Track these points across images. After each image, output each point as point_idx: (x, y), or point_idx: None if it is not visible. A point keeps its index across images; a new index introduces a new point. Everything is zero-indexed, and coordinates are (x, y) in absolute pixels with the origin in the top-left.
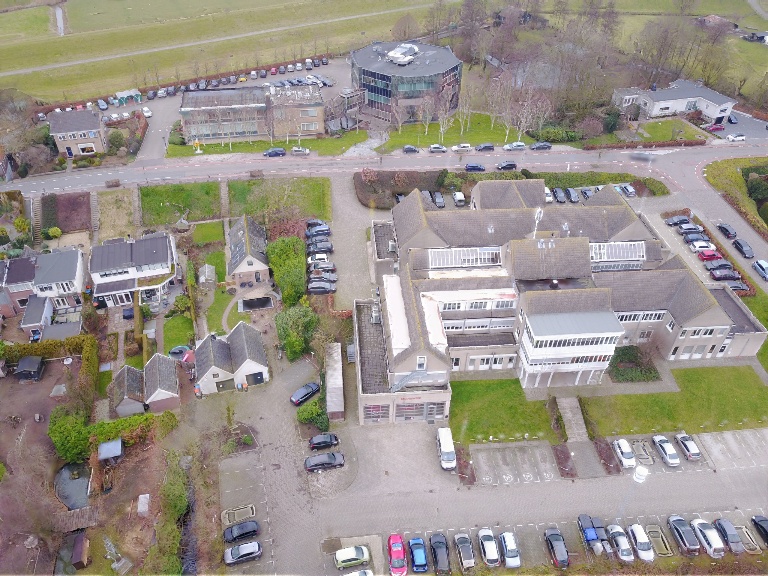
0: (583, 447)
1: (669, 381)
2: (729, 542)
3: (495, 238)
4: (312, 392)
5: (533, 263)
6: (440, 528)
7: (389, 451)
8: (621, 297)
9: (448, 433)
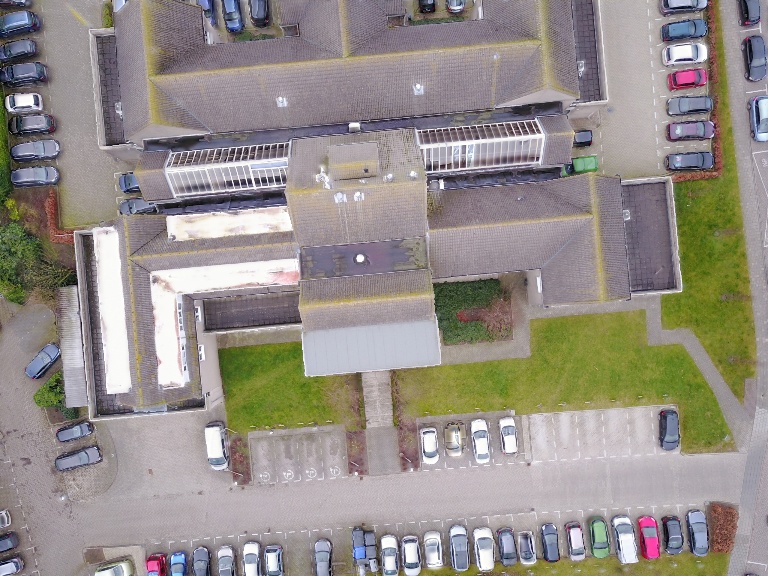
0: (384, 434)
1: (521, 340)
2: (503, 559)
3: (290, 115)
4: (51, 362)
5: (327, 224)
6: (207, 536)
7: (152, 444)
8: (471, 258)
9: (216, 435)
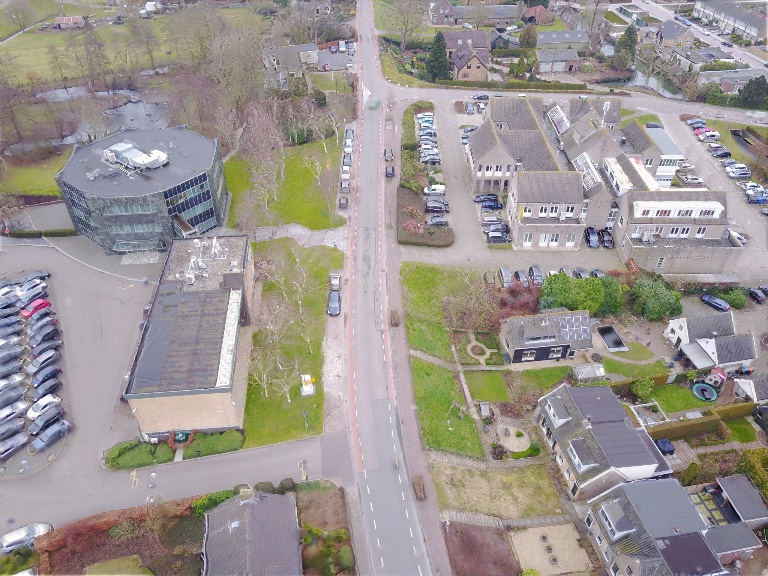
0: None
1: None
2: None
3: None
4: None
5: None
6: None
7: (744, 265)
8: None
9: None
